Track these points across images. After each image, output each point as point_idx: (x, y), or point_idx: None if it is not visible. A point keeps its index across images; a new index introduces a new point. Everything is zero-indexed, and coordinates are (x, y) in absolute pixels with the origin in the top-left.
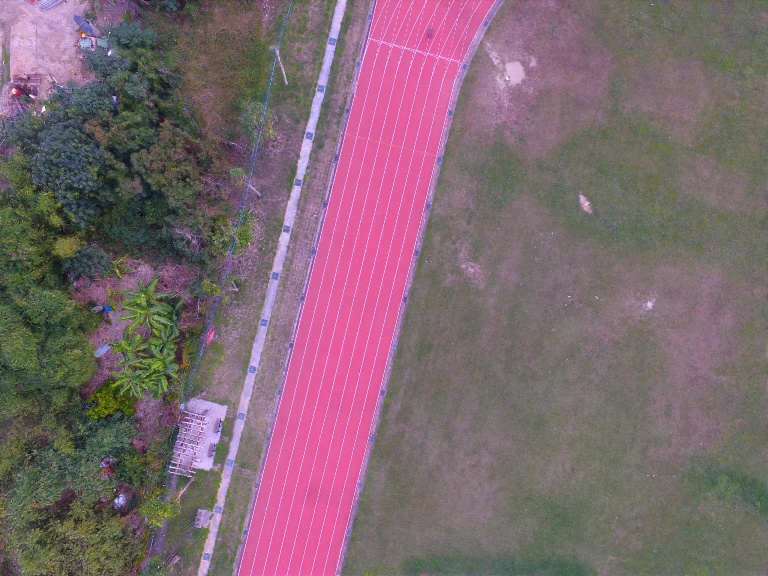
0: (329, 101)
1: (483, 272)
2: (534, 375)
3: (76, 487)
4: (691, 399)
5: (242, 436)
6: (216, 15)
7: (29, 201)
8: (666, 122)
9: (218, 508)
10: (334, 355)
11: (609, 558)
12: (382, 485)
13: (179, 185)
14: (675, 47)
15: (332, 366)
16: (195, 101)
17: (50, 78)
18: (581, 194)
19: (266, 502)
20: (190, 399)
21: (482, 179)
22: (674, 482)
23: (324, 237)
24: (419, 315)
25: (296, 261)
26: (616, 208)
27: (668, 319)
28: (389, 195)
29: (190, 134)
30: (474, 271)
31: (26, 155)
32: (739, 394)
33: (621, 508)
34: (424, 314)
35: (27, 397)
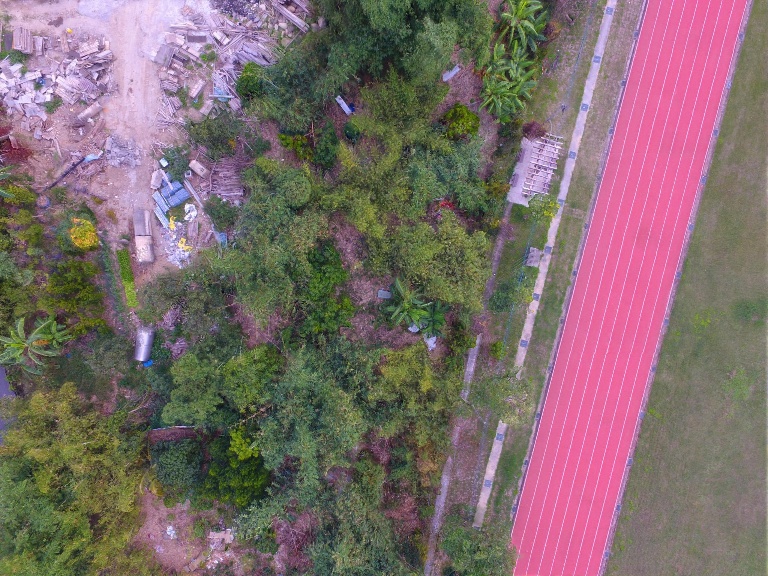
0: None
1: None
2: None
3: (457, 186)
4: None
5: (573, 175)
6: None
7: None
8: None
9: (548, 248)
10: (668, 93)
11: None
12: (713, 227)
13: None
14: None
15: (665, 104)
16: None
17: None
18: None
19: (596, 243)
20: None
21: None
22: None
23: None
24: (755, 52)
25: None
26: None
27: None
28: None
29: None
30: None
31: None
32: None
33: None
34: (760, 51)
35: None
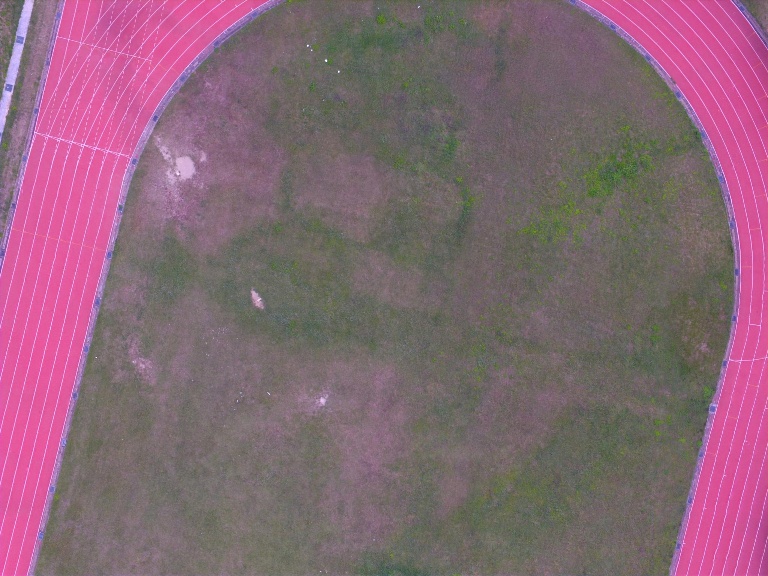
0: None
1: (154, 368)
2: (205, 471)
3: None
4: (364, 495)
5: None
6: None
7: None
8: (338, 218)
9: None
10: (1, 452)
11: None
12: None
13: None
14: (347, 143)
15: None
16: None
17: None
18: (253, 290)
19: None
20: None
21: (152, 275)
22: None
23: None
24: (89, 411)
25: None
26: (288, 304)
27: (341, 415)
28: (57, 290)
29: None
30: (145, 367)
31: None
32: (412, 490)
33: None
34: (94, 410)
35: None
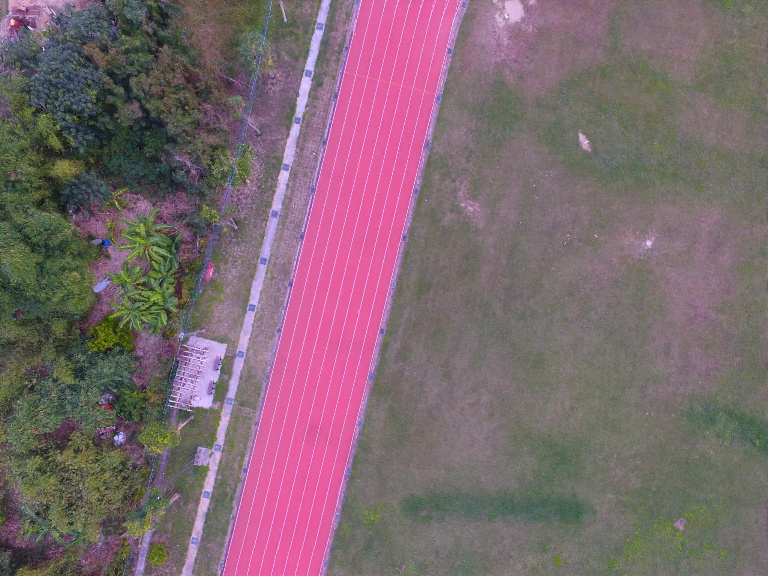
0: (328, 39)
1: (482, 211)
2: (533, 313)
3: (76, 416)
4: (690, 338)
5: (242, 374)
6: None
7: (28, 123)
8: (665, 60)
9: (218, 446)
10: (333, 293)
11: (608, 496)
12: (381, 423)
13: (178, 112)
14: None
15: (331, 304)
16: (194, 32)
17: (49, 10)
18: (580, 132)
19: (266, 440)
20: (189, 337)
21: (481, 117)
22: (673, 420)
23: (323, 175)
24: (418, 254)
25: (295, 199)
26: (615, 146)
27: (667, 258)
28: (388, 133)
29: (189, 64)
30: (473, 210)
31: (25, 77)
32: (738, 332)
33: (620, 446)
34: (423, 252)
35: (26, 325)
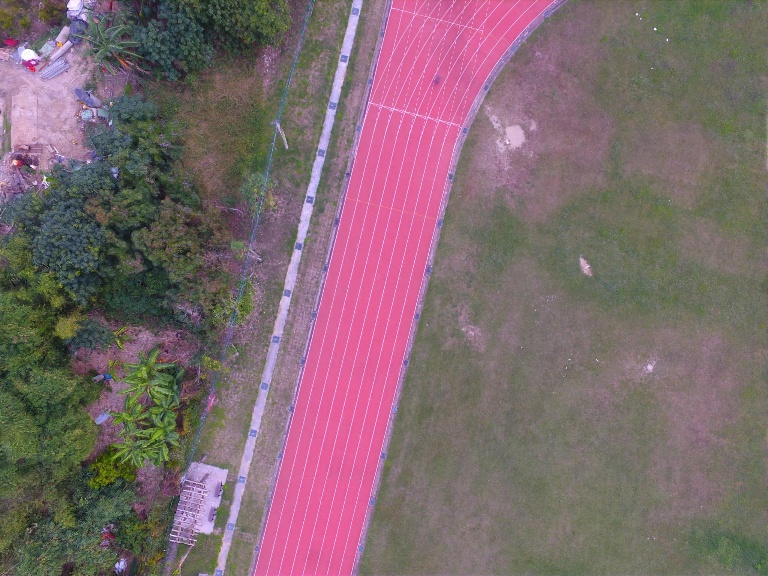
0: (329, 165)
1: (483, 335)
2: (534, 438)
3: (77, 561)
4: (691, 462)
5: (243, 500)
6: (217, 82)
7: (30, 281)
8: (666, 185)
9: (219, 572)
10: (335, 418)
11: None
12: (383, 548)
13: (180, 260)
14: (675, 111)
15: (333, 429)
16: (196, 173)
17: (51, 148)
18: (581, 257)
19: (267, 566)
20: (191, 463)
21: (482, 242)
22: (675, 545)
23: (325, 301)
24: (420, 378)
25: (297, 325)
26: (616, 271)
27: (668, 382)
28: (389, 259)
29: (191, 206)
30: (474, 334)
31: (27, 235)
32: (739, 457)
33: (622, 571)
34: (425, 377)
35: (28, 472)
